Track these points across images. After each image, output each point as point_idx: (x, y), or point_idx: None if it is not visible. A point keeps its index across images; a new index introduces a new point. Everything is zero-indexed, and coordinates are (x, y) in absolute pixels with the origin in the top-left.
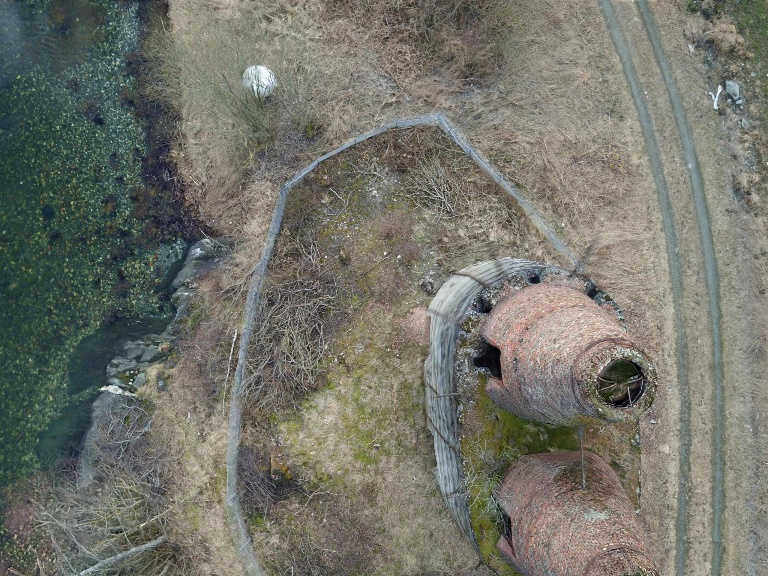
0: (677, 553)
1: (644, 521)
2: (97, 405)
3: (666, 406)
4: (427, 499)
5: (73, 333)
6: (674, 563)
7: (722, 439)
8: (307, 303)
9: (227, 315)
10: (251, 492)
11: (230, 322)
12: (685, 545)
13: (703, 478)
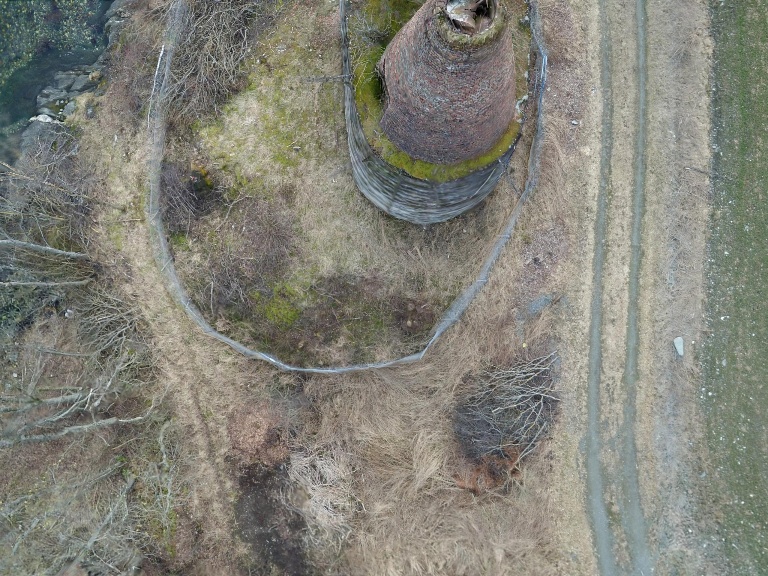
0: (595, 256)
1: (563, 224)
2: (26, 134)
3: (588, 108)
4: (345, 201)
5: (5, 65)
6: (592, 266)
7: (644, 143)
8: (232, 8)
9: (155, 33)
10: (174, 209)
11: (158, 39)
12: (603, 248)
13: (624, 181)
